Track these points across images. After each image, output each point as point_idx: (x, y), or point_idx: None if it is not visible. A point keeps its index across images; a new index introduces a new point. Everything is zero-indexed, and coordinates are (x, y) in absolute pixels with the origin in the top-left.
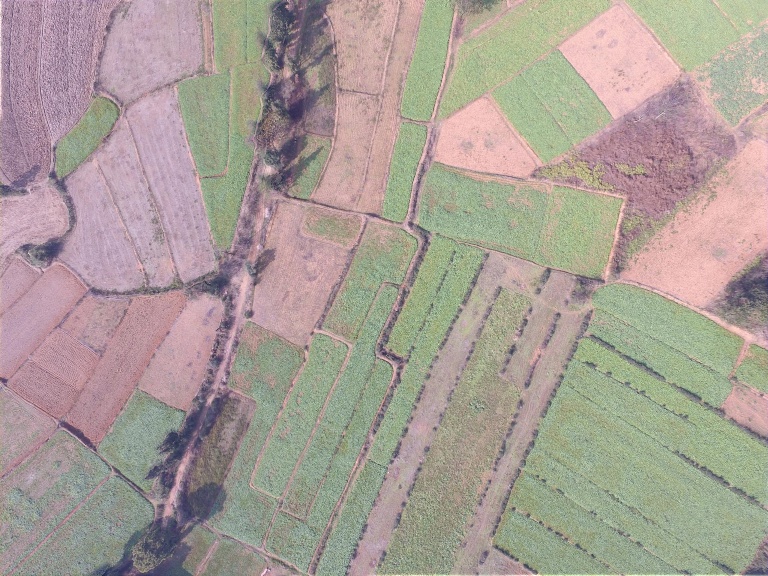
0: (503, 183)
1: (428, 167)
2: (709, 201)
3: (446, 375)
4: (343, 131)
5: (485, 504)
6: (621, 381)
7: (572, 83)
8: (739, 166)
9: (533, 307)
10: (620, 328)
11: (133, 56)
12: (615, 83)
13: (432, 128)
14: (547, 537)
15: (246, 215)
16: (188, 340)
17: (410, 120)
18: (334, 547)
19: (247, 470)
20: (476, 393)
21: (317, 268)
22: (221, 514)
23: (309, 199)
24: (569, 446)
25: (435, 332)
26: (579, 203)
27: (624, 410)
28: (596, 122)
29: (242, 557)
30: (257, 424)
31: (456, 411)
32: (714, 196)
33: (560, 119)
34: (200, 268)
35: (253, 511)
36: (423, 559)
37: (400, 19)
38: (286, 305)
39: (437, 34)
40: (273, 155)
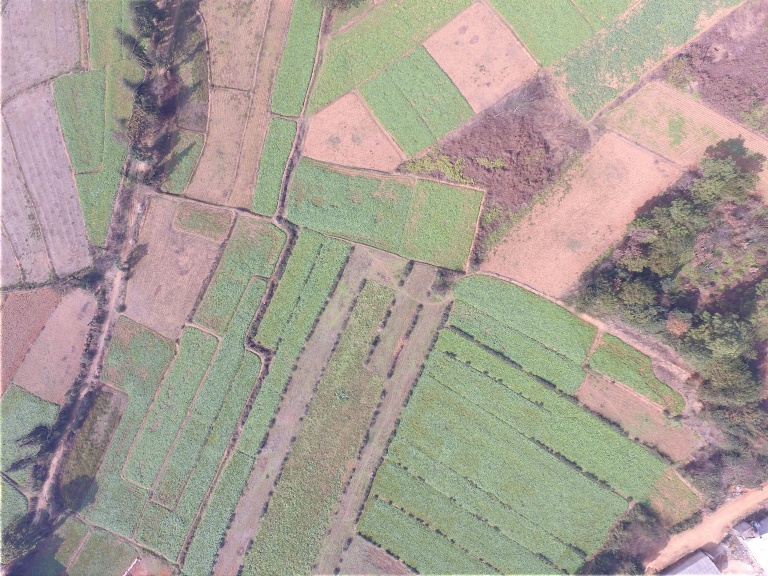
0: (369, 177)
1: (297, 162)
2: (565, 193)
3: (312, 366)
4: (215, 127)
5: (349, 492)
6: (480, 370)
7: (435, 78)
8: (593, 159)
9: (396, 299)
10: (479, 318)
11: (10, 53)
12: (476, 78)
13: (301, 123)
14: (408, 523)
15: (119, 210)
16: (63, 335)
17: (280, 115)
18: (202, 536)
19: (119, 462)
20: (341, 383)
21: (189, 262)
22: (93, 506)
23: (181, 194)
24: (429, 434)
25: (302, 324)
26: (442, 196)
27: (482, 398)
28: (458, 117)
29: (113, 548)
30: (129, 417)
31: (321, 401)
32: (569, 188)
33: (424, 114)
34: (76, 263)
35: (124, 502)
36: (289, 547)
37: (271, 16)
38: (158, 299)
39: (307, 30)
40: (139, 151)
